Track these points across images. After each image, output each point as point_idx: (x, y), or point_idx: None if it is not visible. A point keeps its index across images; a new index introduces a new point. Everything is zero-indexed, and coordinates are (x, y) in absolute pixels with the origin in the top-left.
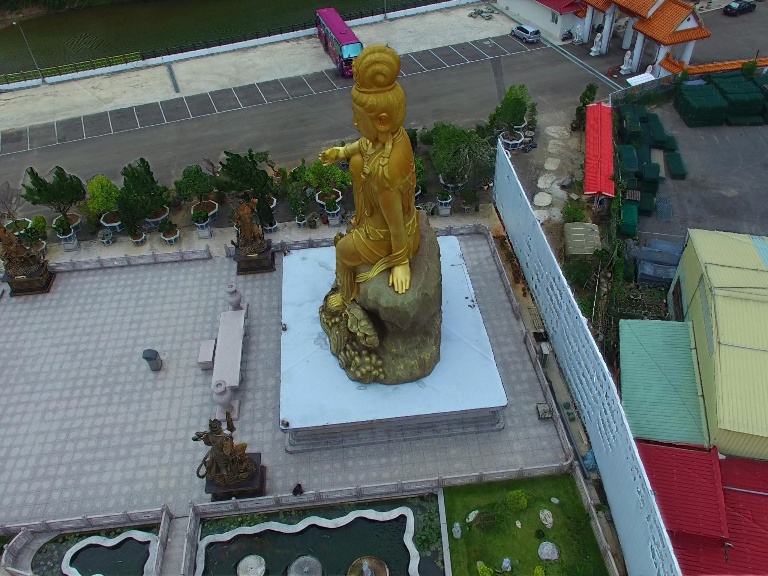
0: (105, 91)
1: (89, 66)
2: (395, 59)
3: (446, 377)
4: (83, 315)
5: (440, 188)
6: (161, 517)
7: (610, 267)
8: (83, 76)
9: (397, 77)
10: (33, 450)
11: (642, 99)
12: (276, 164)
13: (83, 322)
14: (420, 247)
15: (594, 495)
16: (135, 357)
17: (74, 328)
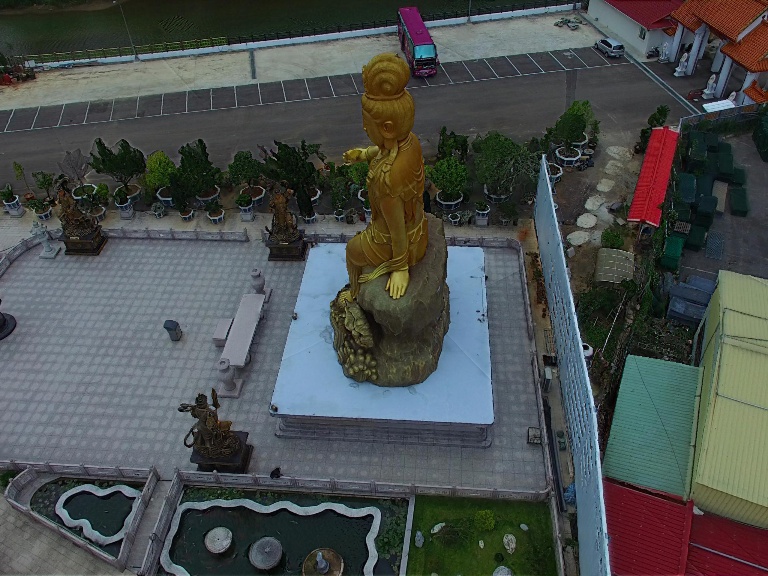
0: (189, 72)
1: (179, 47)
2: (404, 69)
3: (438, 387)
4: (123, 280)
5: (484, 198)
6: (149, 477)
7: (640, 299)
8: (172, 56)
9: (467, 81)
10: (54, 397)
11: (718, 127)
12: (329, 157)
13: (122, 286)
14: (426, 255)
15: (567, 529)
16: (160, 325)
17: (113, 291)
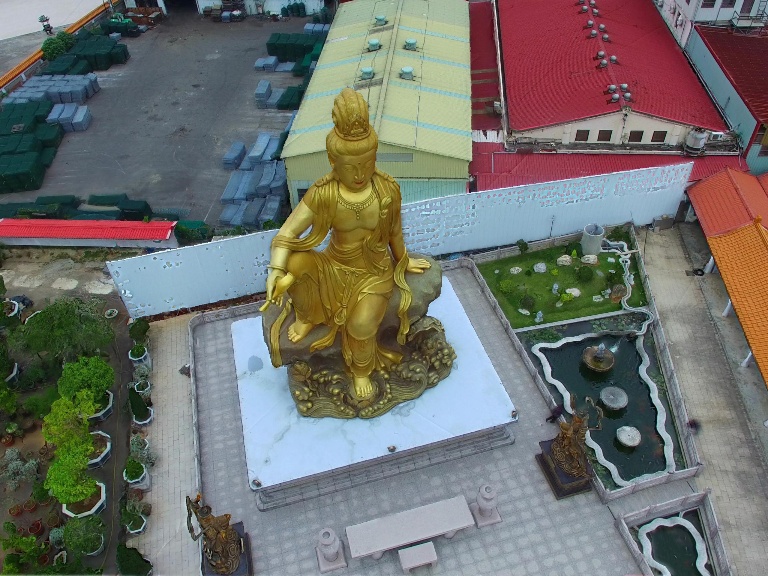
0: None
1: None
2: None
3: (428, 312)
4: None
5: None
6: None
7: None
8: None
9: None
10: None
11: None
12: None
13: None
14: None
15: None
16: None
17: None
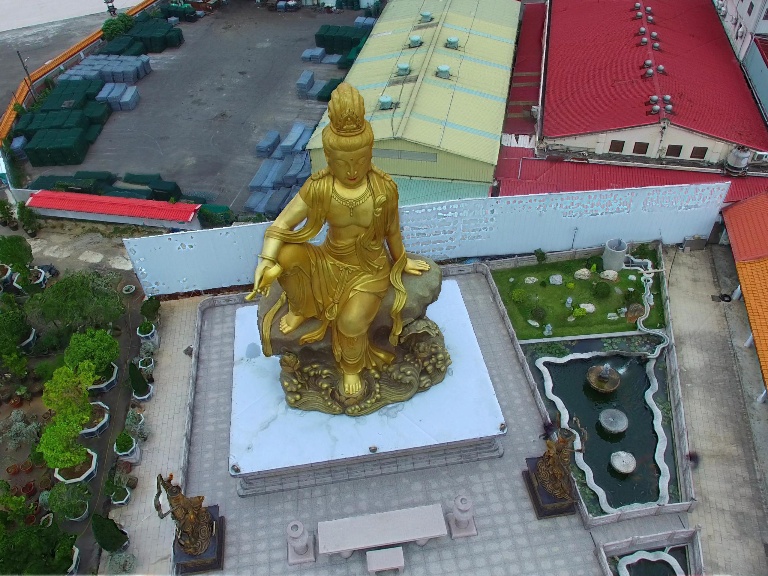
0: None
1: None
2: None
3: (432, 315)
4: None
5: None
6: None
7: None
8: None
9: None
10: None
11: None
12: None
13: None
14: None
15: None
16: None
17: None
